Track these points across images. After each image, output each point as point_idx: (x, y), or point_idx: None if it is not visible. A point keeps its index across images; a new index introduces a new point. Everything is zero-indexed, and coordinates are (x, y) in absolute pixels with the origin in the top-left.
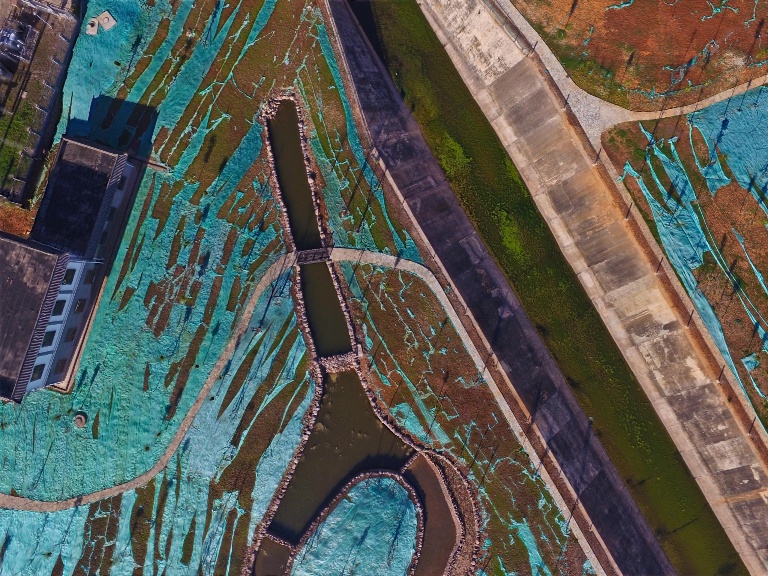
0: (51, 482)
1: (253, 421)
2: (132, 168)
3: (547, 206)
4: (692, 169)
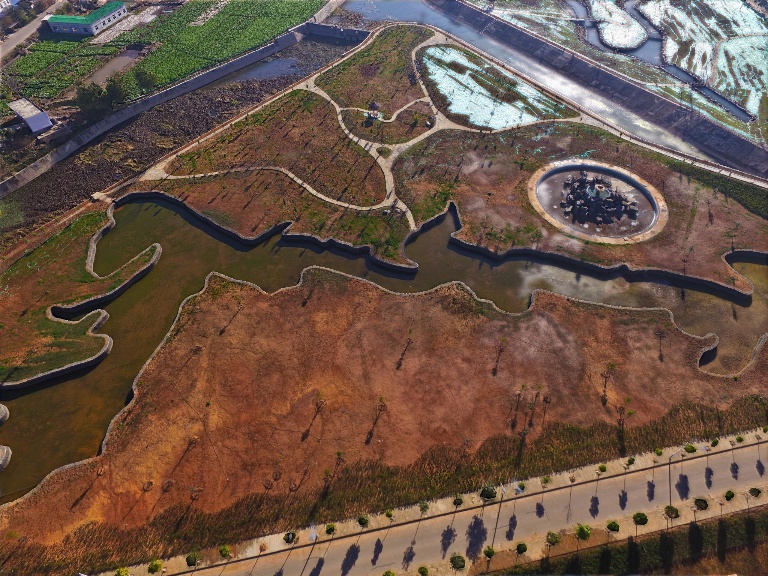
0: (759, 38)
1: None
2: None
3: None
4: (532, 106)
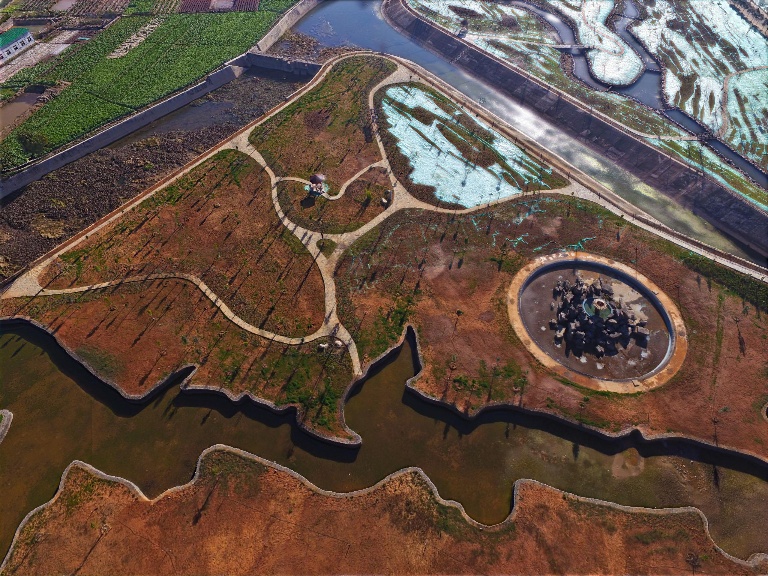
0: None
1: (695, 91)
2: None
3: (580, 171)
4: (512, 172)
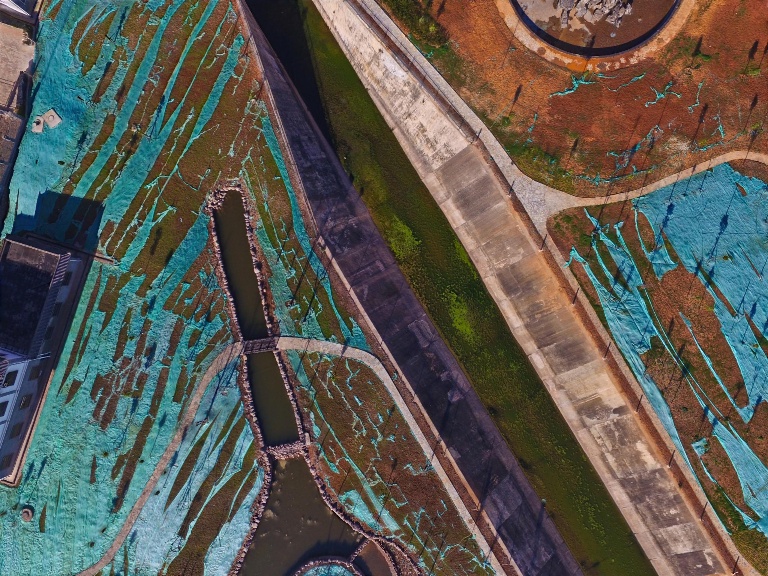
0: None
1: (201, 512)
2: (78, 262)
3: (496, 288)
4: (638, 254)
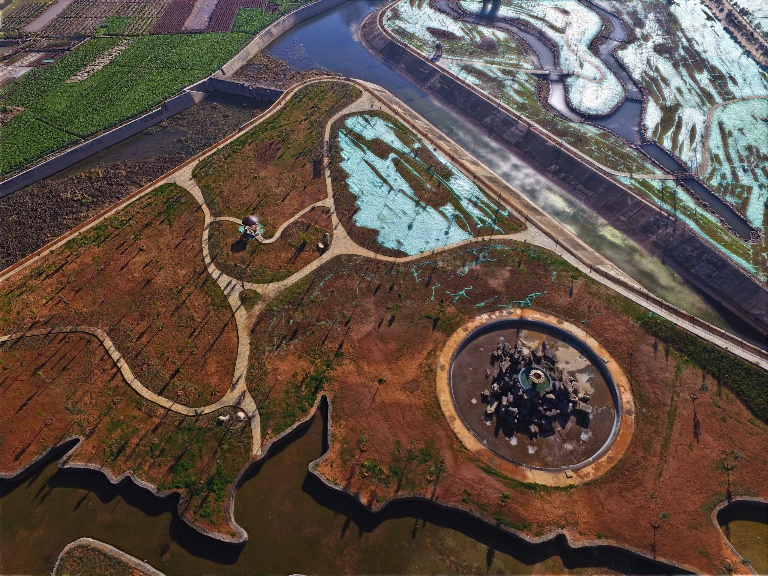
0: (762, 103)
1: (676, 123)
2: None
3: None
4: (465, 214)
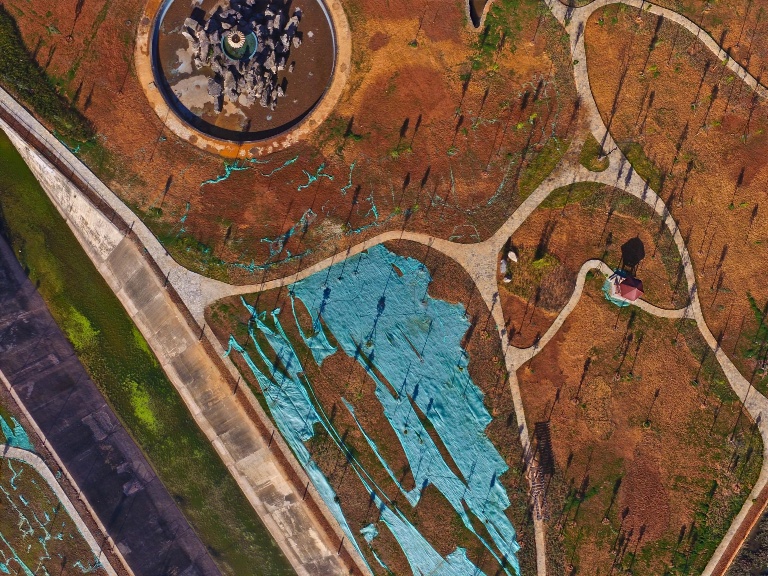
0: None
1: None
2: None
3: (174, 376)
4: (297, 340)
